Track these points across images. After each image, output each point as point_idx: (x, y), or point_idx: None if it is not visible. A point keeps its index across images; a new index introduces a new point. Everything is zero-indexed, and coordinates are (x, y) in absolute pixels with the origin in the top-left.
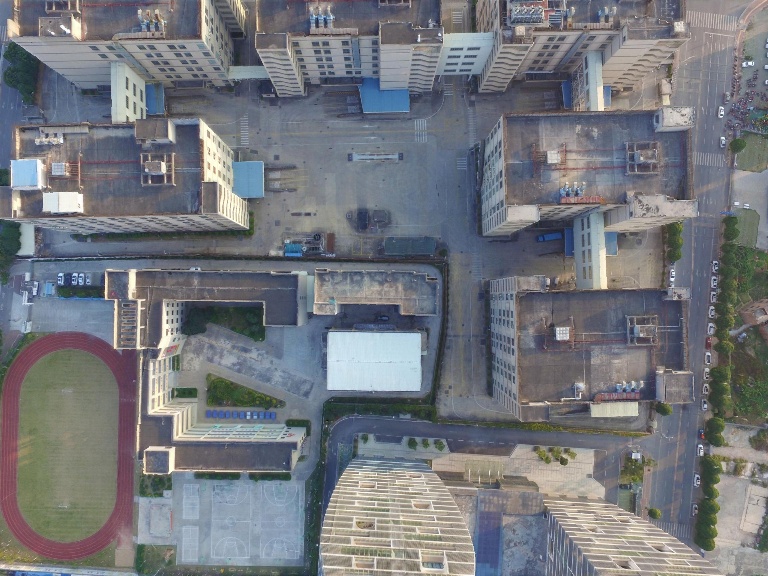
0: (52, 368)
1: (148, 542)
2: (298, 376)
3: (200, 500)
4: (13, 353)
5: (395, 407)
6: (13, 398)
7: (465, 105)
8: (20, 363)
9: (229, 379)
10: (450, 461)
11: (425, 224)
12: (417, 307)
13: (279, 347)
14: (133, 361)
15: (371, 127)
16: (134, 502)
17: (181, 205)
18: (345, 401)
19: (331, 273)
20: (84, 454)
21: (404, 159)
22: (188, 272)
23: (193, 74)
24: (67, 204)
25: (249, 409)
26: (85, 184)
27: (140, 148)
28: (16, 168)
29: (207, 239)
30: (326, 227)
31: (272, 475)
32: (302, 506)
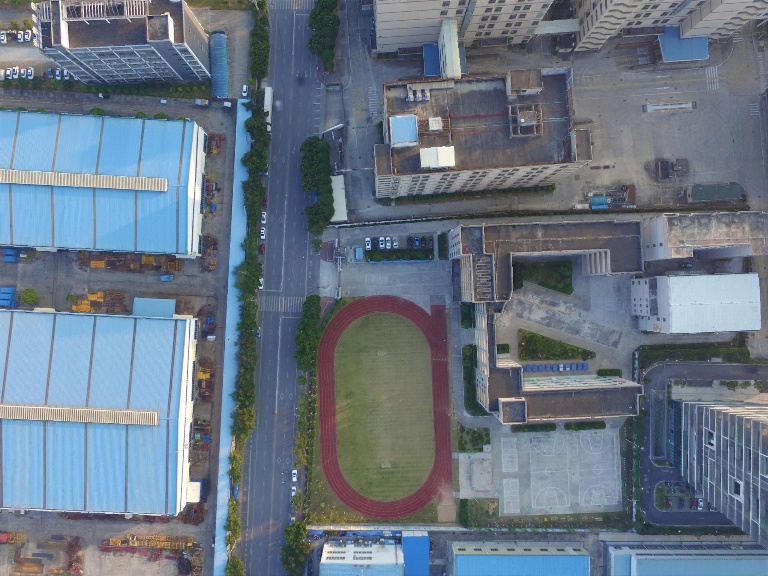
0: (364, 332)
1: (470, 496)
2: (606, 327)
3: (518, 453)
4: (326, 319)
5: (710, 351)
6: (328, 364)
7: (754, 51)
8: (332, 329)
9: (539, 333)
10: (760, 401)
11: (722, 171)
12: (764, 246)
13: (586, 299)
14: (442, 321)
15: (663, 77)
16: (452, 459)
17: (548, 155)
18: (655, 348)
19: (679, 217)
20: (401, 414)
21: (698, 107)
22: (532, 225)
23: (505, 30)
24: (445, 158)
25: (561, 362)
26: (453, 139)
27: (505, 100)
28: (395, 125)
29: (509, 197)
30: (625, 179)
31: (588, 424)
32: (618, 453)
